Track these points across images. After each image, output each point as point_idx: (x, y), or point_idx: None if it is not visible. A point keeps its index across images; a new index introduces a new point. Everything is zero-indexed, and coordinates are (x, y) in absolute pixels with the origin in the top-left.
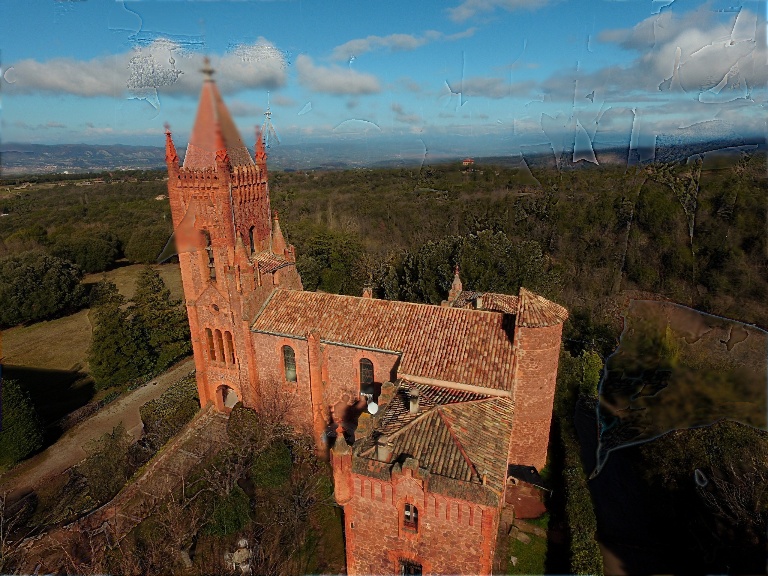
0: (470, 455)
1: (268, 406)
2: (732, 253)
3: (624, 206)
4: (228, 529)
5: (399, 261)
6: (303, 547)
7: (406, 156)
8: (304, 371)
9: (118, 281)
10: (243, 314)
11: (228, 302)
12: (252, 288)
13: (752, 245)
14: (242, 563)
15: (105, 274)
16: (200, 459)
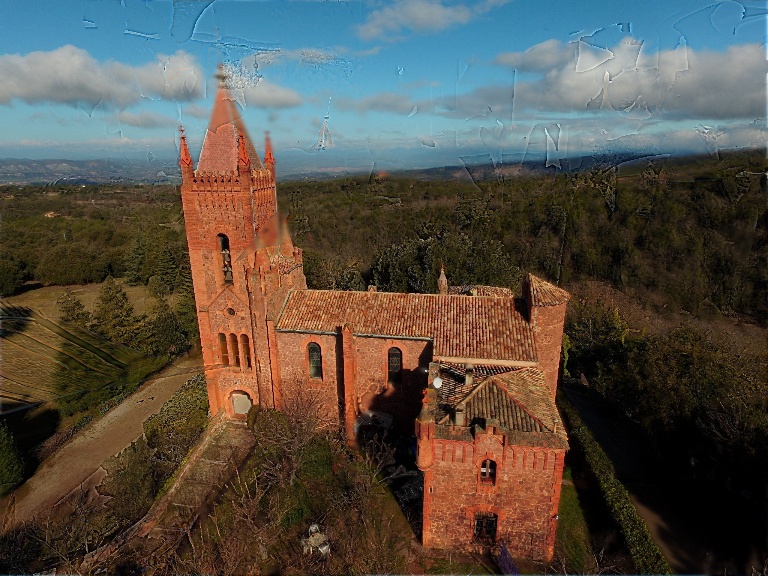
0: (532, 412)
1: (290, 405)
2: (652, 245)
3: (553, 210)
4: (293, 519)
5: (362, 266)
6: (370, 524)
7: (350, 166)
8: (331, 366)
9: (34, 305)
10: (268, 314)
11: (246, 305)
12: (275, 288)
13: (667, 238)
14: (320, 545)
15: (69, 290)
16: (226, 465)
